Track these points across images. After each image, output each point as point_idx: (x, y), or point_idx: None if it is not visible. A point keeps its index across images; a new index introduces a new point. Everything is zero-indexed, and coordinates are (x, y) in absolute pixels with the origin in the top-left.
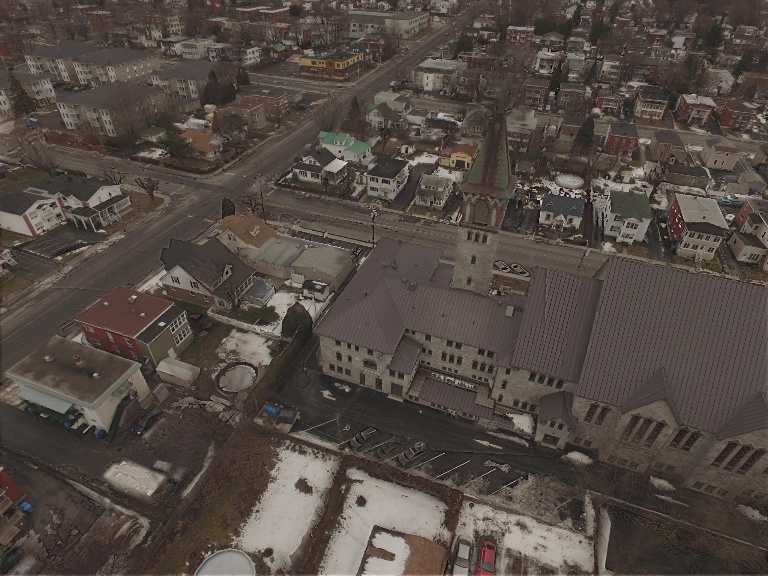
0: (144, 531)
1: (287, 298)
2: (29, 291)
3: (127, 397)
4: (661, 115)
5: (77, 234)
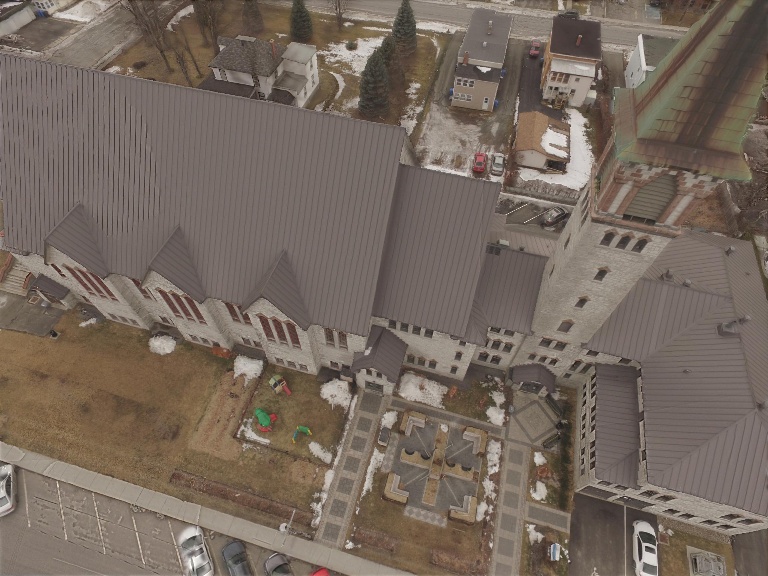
0: None
1: None
2: None
3: None
4: None
5: None
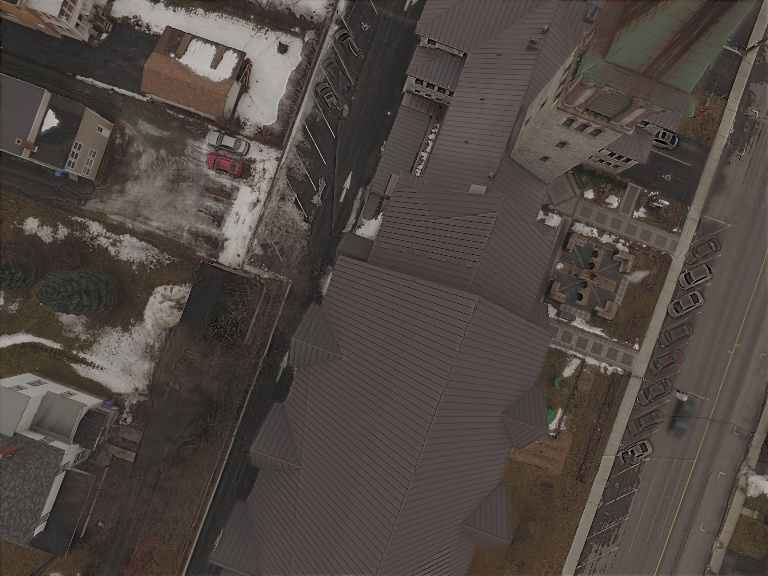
0: None
1: None
2: None
3: None
4: None
5: None
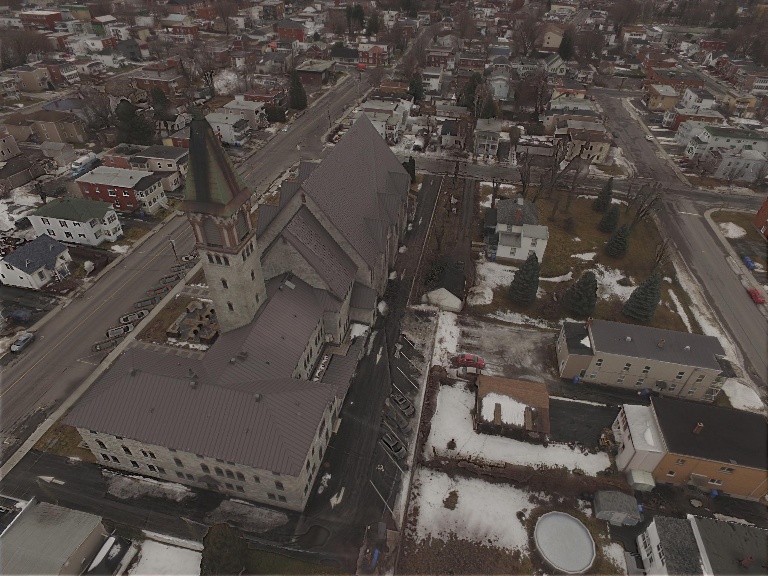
0: None
1: None
2: None
3: None
4: None
5: None
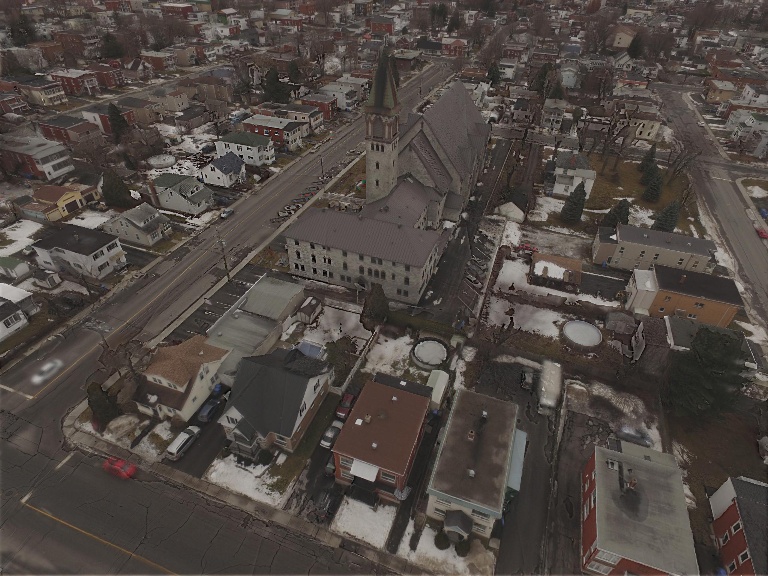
0: None
1: (314, 335)
2: None
3: None
4: (65, 96)
5: None
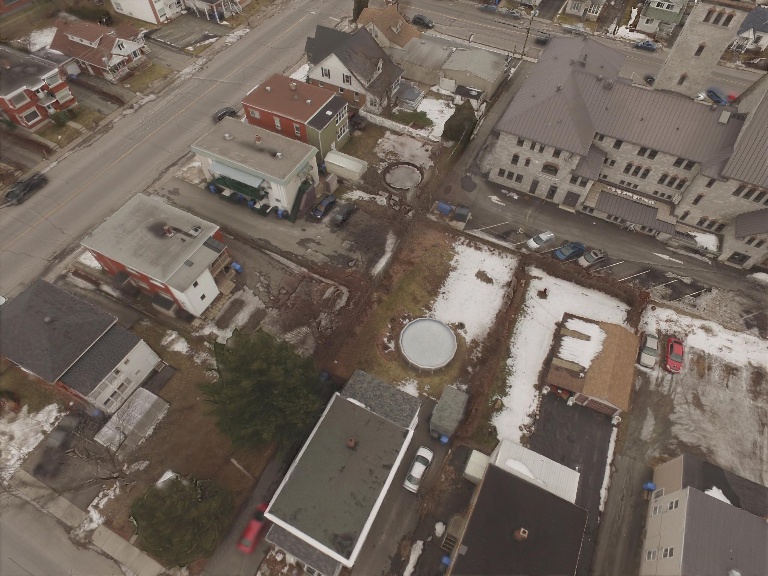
0: (345, 297)
1: (437, 104)
2: (171, 80)
3: (306, 181)
4: None
5: (201, 25)
